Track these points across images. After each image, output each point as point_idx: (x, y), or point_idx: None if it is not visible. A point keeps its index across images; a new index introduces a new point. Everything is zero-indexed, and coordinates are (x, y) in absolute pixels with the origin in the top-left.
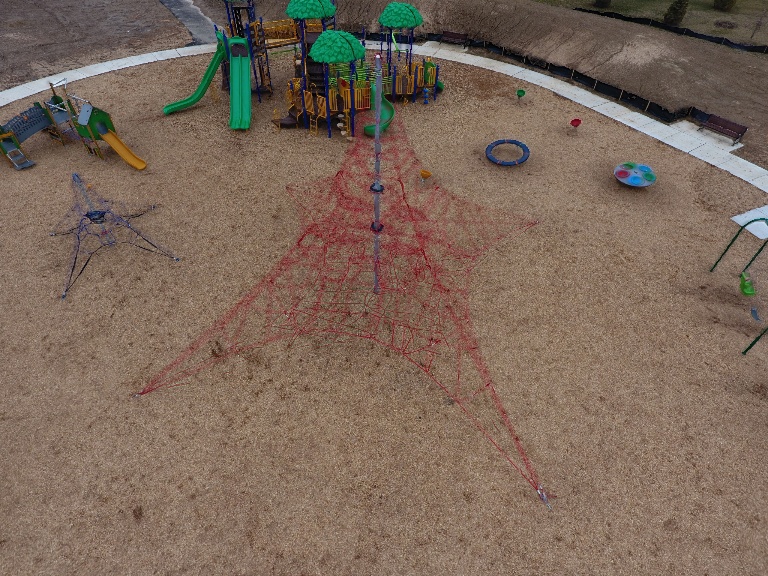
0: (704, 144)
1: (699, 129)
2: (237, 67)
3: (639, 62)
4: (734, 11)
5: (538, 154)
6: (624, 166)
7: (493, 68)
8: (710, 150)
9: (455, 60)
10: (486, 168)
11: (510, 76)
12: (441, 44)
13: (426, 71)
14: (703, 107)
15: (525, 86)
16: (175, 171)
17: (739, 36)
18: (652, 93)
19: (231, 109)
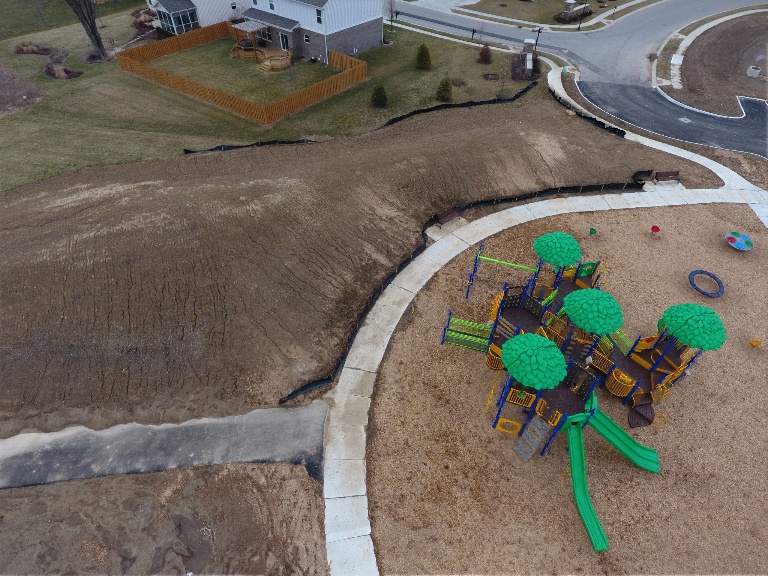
0: (676, 192)
1: (656, 184)
2: (596, 423)
3: (562, 156)
4: (431, 66)
5: (696, 268)
6: (729, 240)
7: (516, 221)
8: (684, 194)
9: (487, 235)
10: (721, 304)
11: (538, 220)
12: (440, 227)
13: (581, 270)
14: (625, 166)
15: (563, 221)
16: (761, 559)
17: (482, 90)
18: (600, 174)
19: (636, 461)
